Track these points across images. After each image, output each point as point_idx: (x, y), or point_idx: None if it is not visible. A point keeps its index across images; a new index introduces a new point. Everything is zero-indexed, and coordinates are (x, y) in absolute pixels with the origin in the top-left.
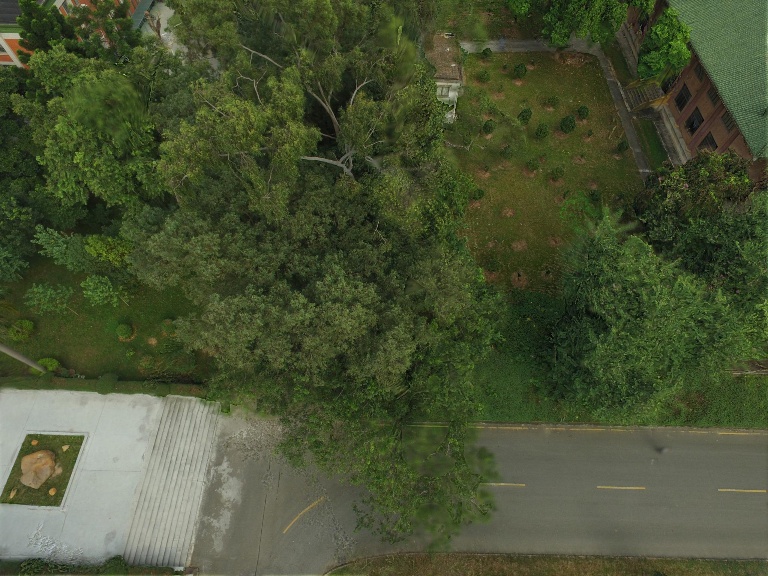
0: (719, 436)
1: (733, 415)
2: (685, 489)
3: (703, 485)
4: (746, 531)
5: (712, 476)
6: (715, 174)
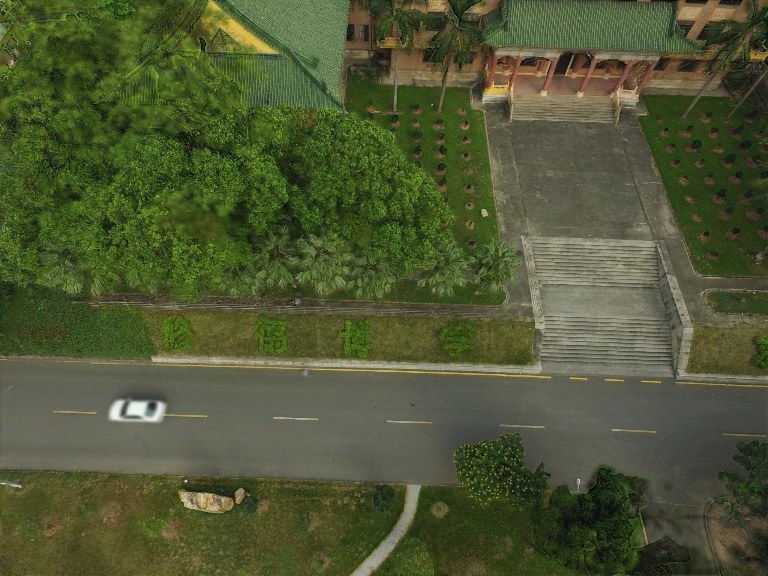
0: (90, 365)
1: (94, 345)
2: (22, 411)
3: (42, 407)
4: (53, 447)
5: (56, 400)
6: (18, 113)
